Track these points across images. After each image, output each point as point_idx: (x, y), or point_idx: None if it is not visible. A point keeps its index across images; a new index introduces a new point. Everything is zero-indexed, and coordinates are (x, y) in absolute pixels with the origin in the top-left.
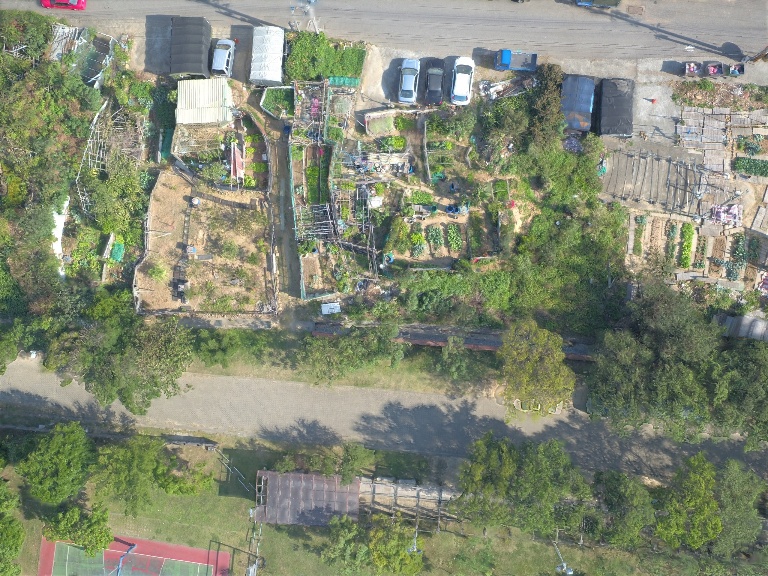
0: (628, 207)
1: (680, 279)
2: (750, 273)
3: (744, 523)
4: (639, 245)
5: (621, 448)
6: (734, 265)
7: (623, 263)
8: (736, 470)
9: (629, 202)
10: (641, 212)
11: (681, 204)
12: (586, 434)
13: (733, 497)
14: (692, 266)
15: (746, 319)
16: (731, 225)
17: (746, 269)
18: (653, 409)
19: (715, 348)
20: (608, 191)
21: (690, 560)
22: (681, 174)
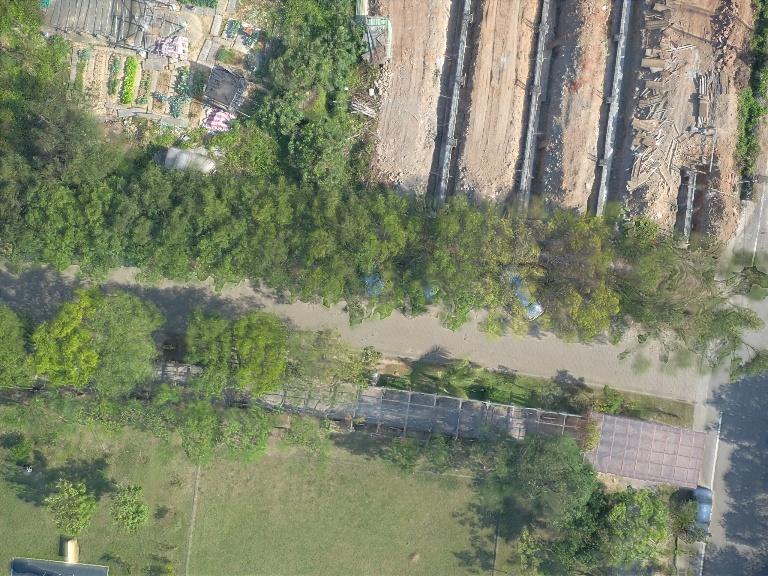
0: (71, 40)
1: (122, 115)
2: (194, 109)
3: (121, 355)
4: (80, 80)
5: (62, 297)
6: (176, 100)
7: (64, 99)
8: (119, 300)
9: (72, 35)
10: (85, 46)
11: (125, 37)
12: (26, 283)
13: (107, 326)
14: (135, 102)
15: (171, 151)
16: (176, 58)
17: (190, 104)
18: (31, 235)
19: (120, 176)
20: (52, 24)
21: (79, 401)
22: (126, 5)
